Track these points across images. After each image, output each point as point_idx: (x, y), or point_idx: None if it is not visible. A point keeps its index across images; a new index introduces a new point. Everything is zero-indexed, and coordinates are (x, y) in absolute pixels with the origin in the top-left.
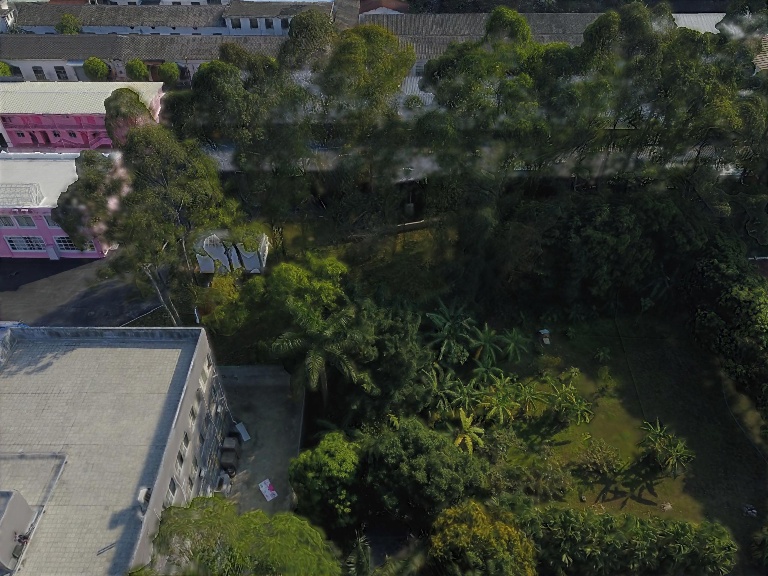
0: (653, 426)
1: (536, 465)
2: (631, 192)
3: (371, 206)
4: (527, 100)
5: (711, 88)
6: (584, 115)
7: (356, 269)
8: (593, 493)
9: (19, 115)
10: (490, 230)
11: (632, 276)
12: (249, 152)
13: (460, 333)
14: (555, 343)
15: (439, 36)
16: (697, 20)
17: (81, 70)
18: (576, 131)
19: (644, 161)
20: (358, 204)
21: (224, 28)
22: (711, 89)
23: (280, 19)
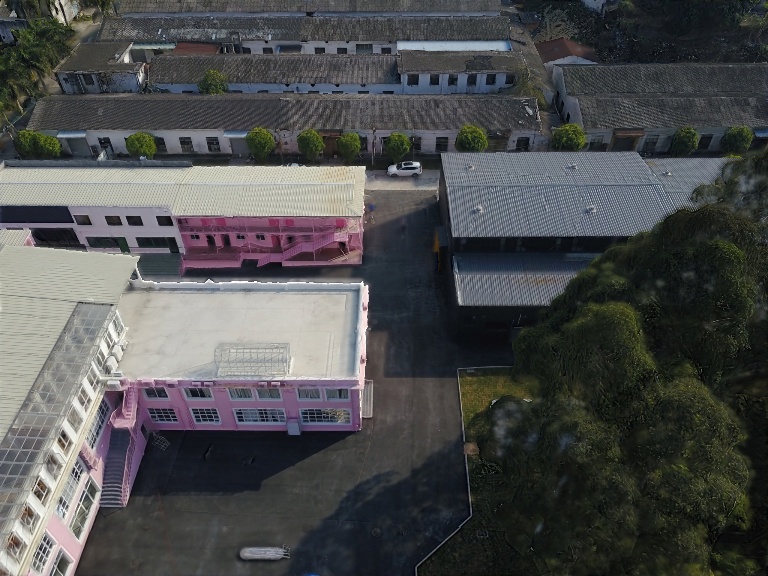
0: None
1: None
2: None
3: None
4: None
5: None
6: None
7: None
8: None
9: (203, 218)
10: None
11: None
12: (726, 368)
13: None
14: None
15: (671, 98)
16: None
17: (238, 141)
18: None
19: None
20: None
21: (398, 85)
22: None
23: (467, 75)
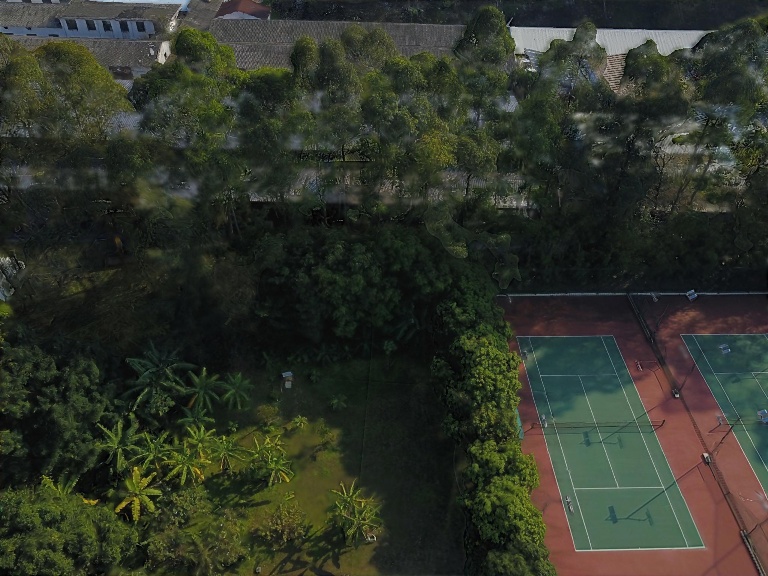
0: (346, 489)
1: (209, 532)
2: (380, 227)
3: (58, 241)
4: (214, 131)
5: (427, 122)
6: (287, 148)
7: (110, 300)
8: (271, 563)
9: None
10: (207, 268)
11: (379, 317)
12: None
13: (162, 381)
14: (297, 387)
15: (279, 45)
16: (559, 35)
17: None
18: (276, 165)
19: (380, 196)
20: (45, 239)
21: (60, 29)
22: (427, 123)
23: (118, 21)
